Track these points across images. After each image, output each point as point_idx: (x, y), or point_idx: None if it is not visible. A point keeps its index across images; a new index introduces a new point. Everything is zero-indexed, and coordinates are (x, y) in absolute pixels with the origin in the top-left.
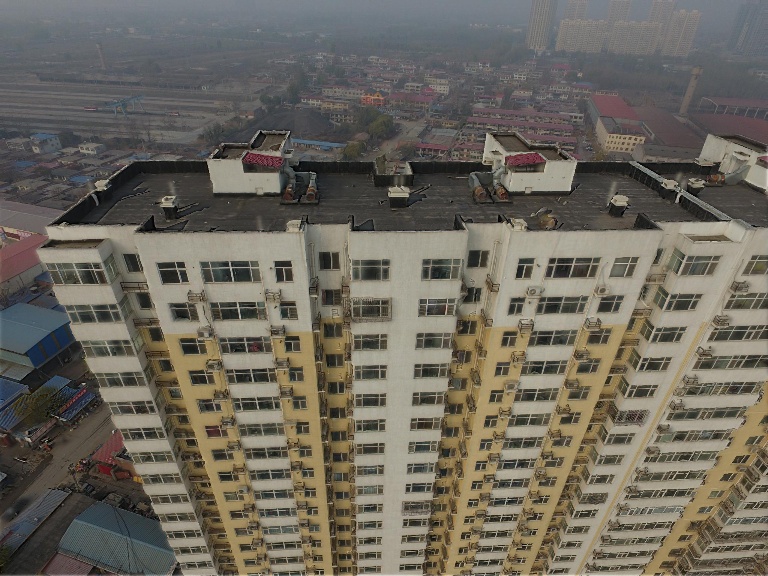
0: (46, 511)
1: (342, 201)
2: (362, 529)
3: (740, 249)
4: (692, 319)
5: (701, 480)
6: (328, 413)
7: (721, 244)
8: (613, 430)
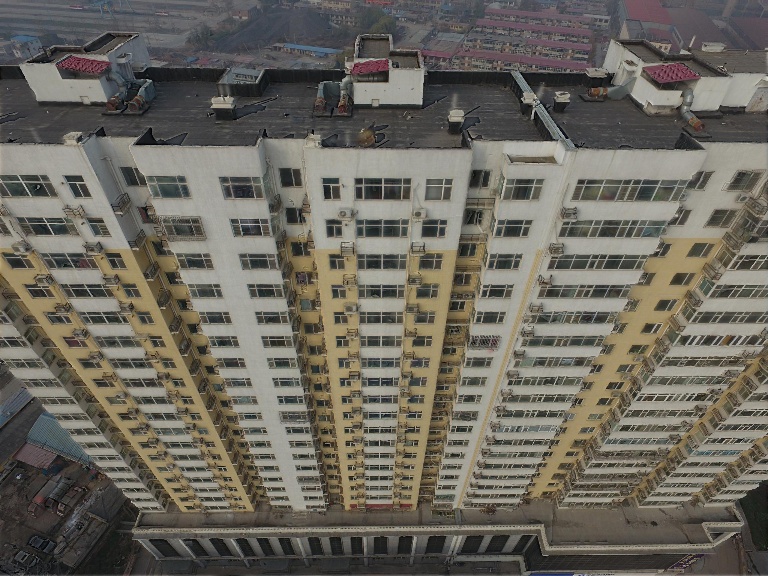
0: (18, 407)
1: (171, 112)
2: (249, 434)
3: (563, 172)
4: (526, 246)
5: (570, 403)
6: (186, 329)
7: (540, 166)
8: (469, 354)
